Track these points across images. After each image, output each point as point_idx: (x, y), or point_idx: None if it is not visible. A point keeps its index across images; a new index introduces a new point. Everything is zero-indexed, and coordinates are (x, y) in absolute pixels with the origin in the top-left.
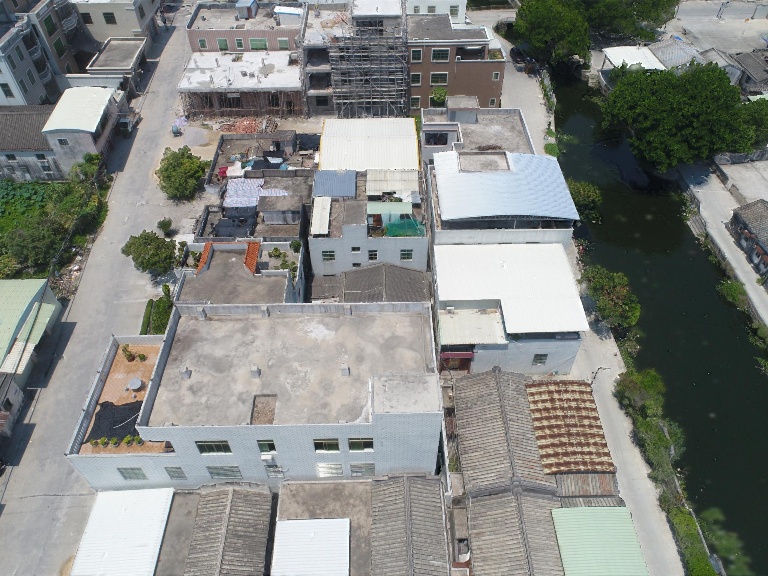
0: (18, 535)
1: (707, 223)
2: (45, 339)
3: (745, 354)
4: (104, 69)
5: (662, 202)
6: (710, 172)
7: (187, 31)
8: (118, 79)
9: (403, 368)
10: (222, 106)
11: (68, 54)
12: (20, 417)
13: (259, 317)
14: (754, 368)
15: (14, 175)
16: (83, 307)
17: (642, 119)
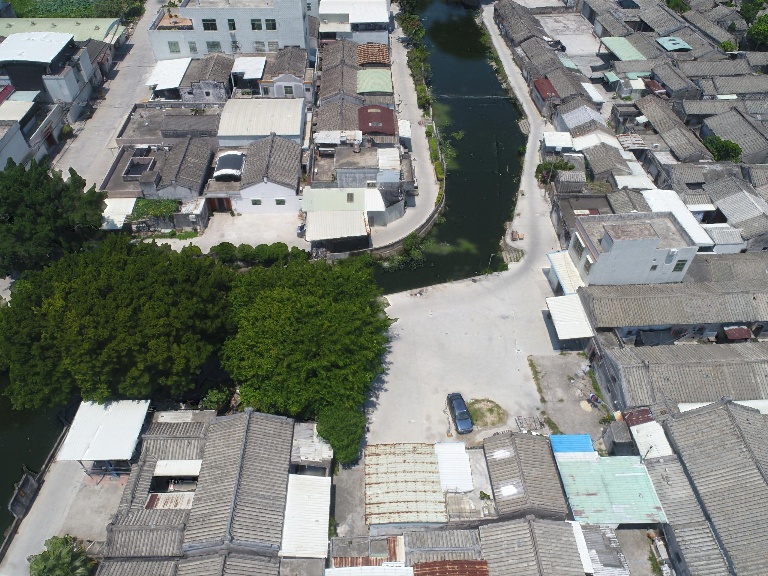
0: (118, 95)
1: (484, 17)
2: (119, 48)
3: (482, 59)
4: None
5: (465, 13)
6: (496, 0)
7: None
8: None
9: None
10: None
11: None
12: (111, 69)
13: None
14: (484, 62)
15: None
16: (137, 40)
17: None
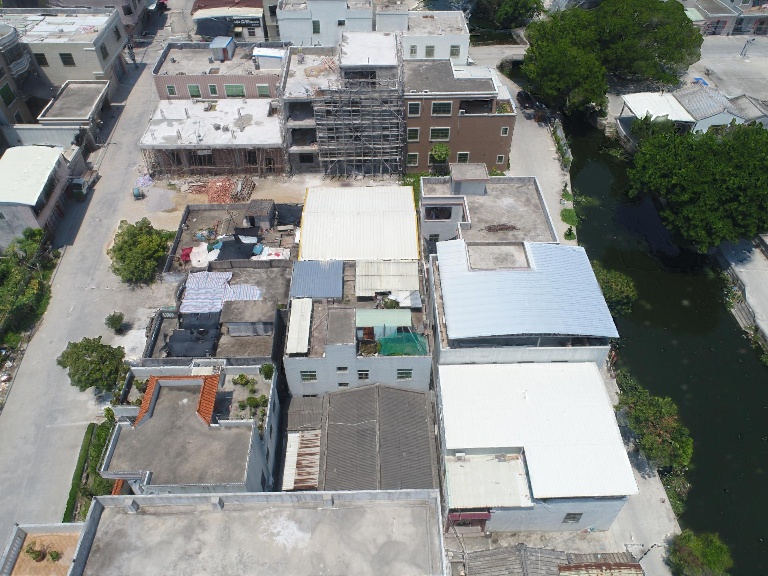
0: None
1: (756, 313)
2: None
3: None
4: (58, 119)
5: (700, 283)
6: (753, 246)
7: (153, 76)
8: (74, 130)
9: None
10: (192, 164)
11: (18, 101)
12: None
13: (209, 509)
14: None
15: None
16: (8, 433)
17: (678, 191)
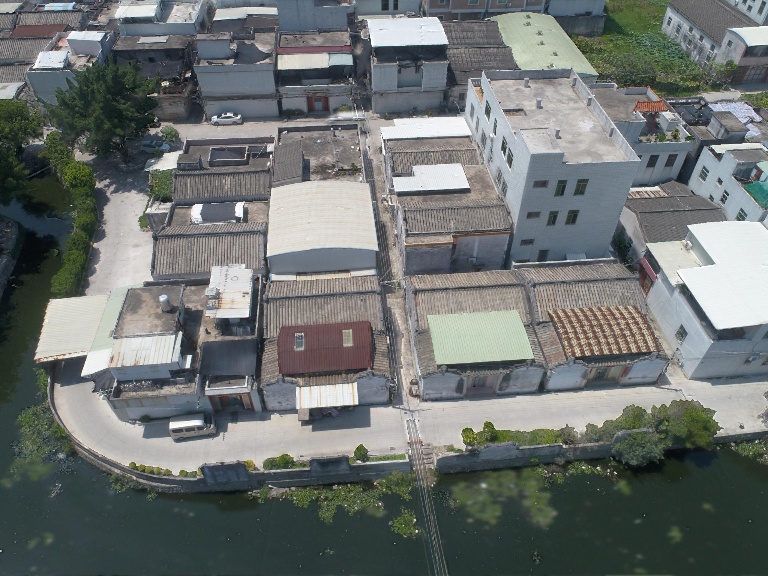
0: None
1: None
2: None
3: None
4: None
5: None
6: None
7: None
8: None
9: (573, 160)
10: None
11: None
12: None
13: None
14: None
15: (693, 53)
16: None
17: None
